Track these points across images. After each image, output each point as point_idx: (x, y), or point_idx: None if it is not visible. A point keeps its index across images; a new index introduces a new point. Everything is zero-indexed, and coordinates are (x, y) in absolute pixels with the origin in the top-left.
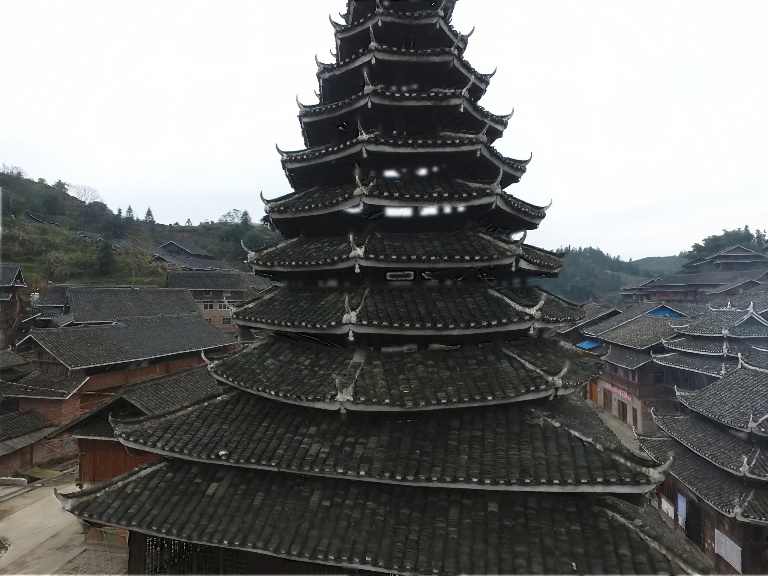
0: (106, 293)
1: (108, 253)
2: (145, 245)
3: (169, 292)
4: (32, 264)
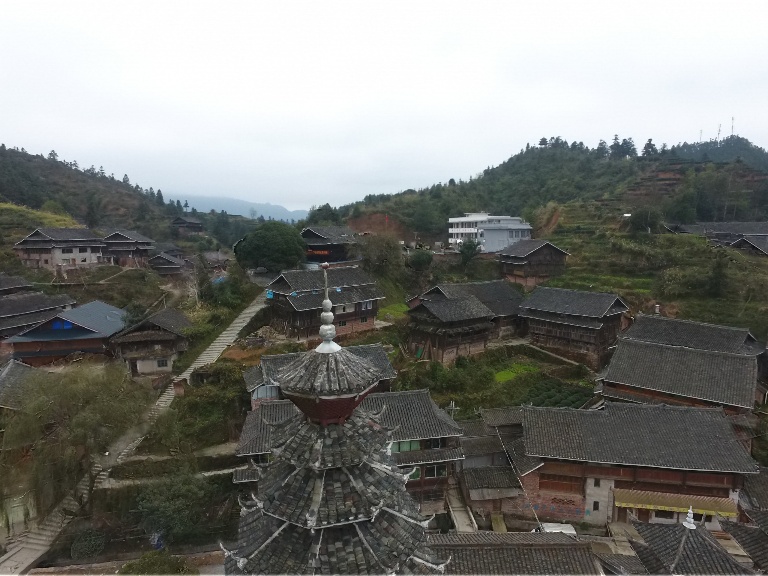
0: (652, 349)
1: (719, 273)
2: (764, 266)
3: (726, 357)
4: (651, 280)
